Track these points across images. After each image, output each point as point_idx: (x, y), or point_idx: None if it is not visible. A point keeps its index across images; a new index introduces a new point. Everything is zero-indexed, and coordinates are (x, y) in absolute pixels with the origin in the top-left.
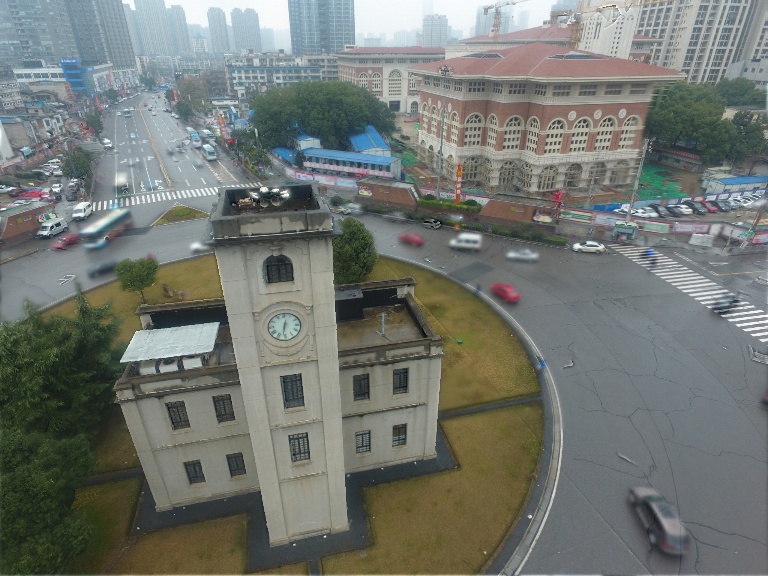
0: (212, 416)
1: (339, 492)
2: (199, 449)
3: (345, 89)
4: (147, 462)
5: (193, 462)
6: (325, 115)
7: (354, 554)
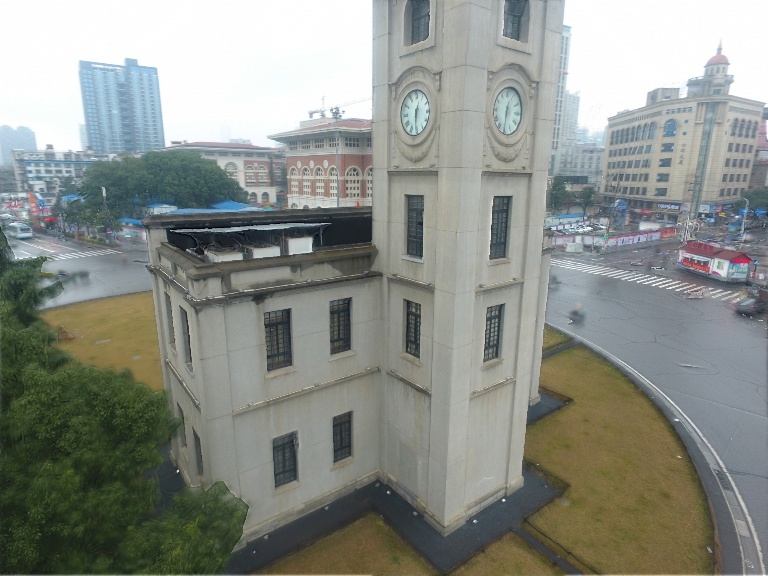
0: (324, 340)
1: (521, 414)
2: (299, 408)
3: (200, 158)
4: (220, 442)
5: (283, 440)
6: (181, 182)
7: (557, 504)
